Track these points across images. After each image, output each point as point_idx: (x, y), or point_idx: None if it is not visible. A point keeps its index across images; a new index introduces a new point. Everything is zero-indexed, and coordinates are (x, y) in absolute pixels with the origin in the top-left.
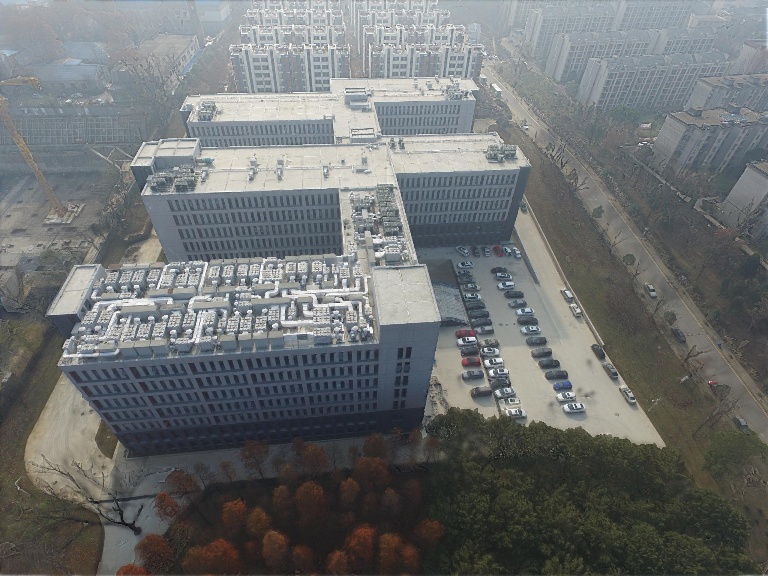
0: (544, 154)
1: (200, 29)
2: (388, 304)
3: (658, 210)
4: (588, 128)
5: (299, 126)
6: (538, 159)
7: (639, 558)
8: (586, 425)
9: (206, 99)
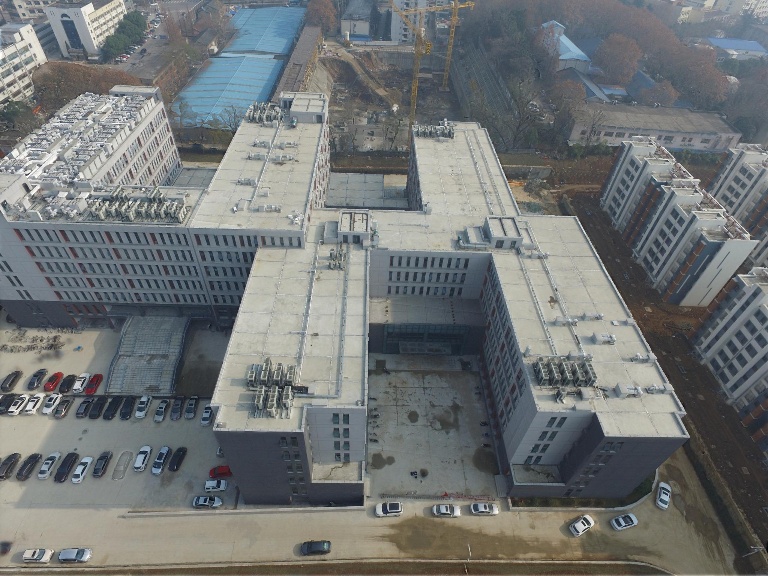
0: None
1: (767, 136)
2: None
3: None
4: None
5: None
6: None
7: None
8: None
9: (474, 132)
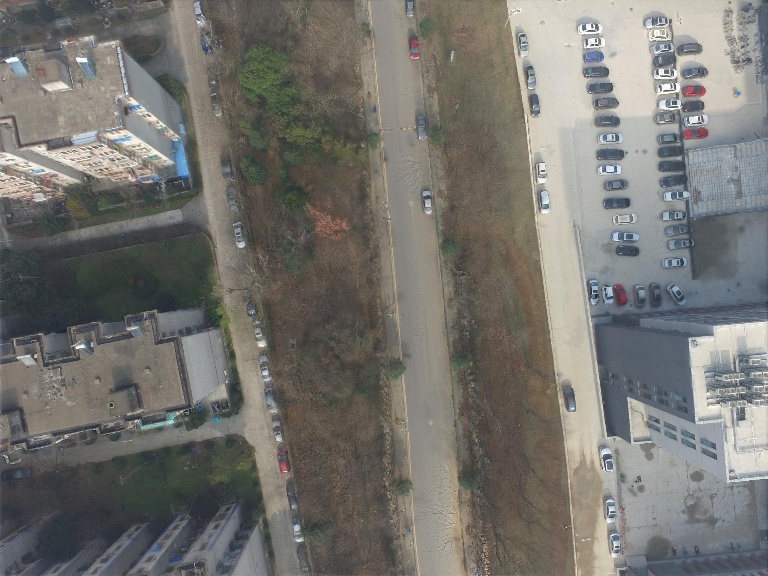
0: None
1: None
2: None
3: None
4: None
5: None
6: None
7: None
8: (581, 11)
9: None
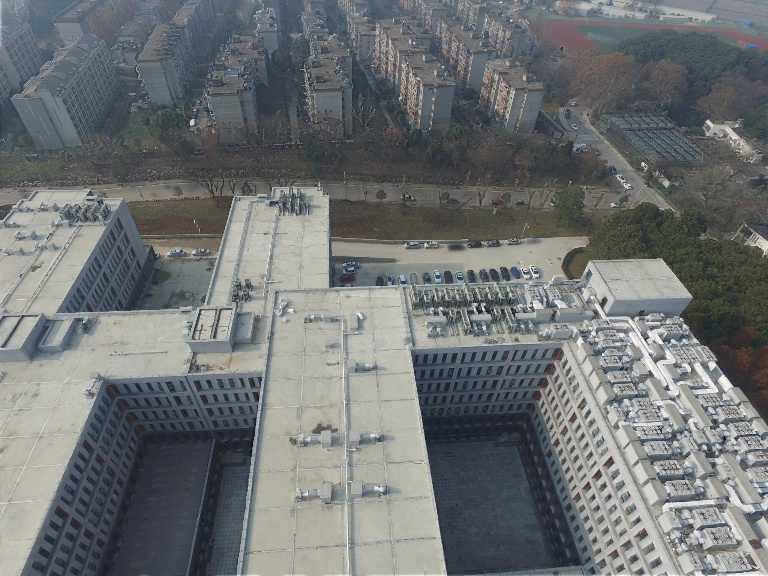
0: (188, 199)
1: None
2: (661, 291)
3: (312, 161)
4: (181, 149)
5: (78, 455)
6: (201, 205)
7: (695, 246)
8: (546, 270)
9: None
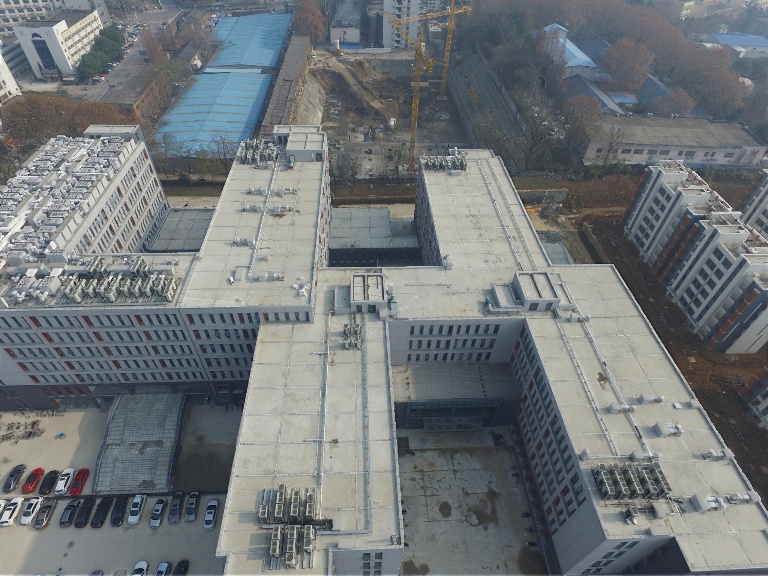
0: None
1: None
2: None
3: None
4: None
5: None
6: None
7: None
8: None
9: (488, 162)
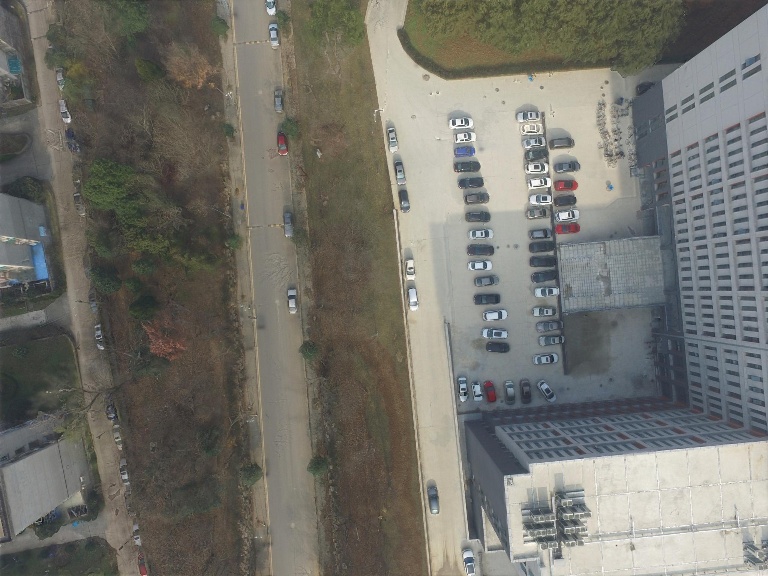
0: None
1: None
2: None
3: None
4: None
5: None
6: None
7: None
8: (453, 105)
9: None
